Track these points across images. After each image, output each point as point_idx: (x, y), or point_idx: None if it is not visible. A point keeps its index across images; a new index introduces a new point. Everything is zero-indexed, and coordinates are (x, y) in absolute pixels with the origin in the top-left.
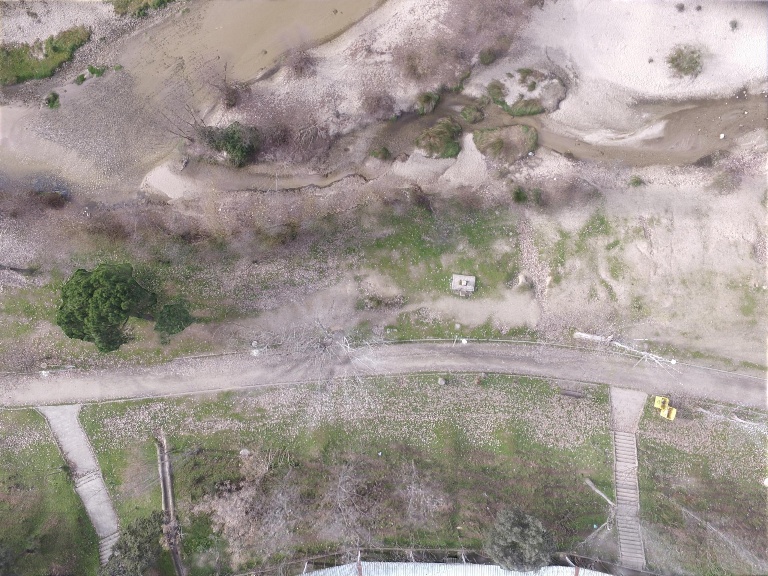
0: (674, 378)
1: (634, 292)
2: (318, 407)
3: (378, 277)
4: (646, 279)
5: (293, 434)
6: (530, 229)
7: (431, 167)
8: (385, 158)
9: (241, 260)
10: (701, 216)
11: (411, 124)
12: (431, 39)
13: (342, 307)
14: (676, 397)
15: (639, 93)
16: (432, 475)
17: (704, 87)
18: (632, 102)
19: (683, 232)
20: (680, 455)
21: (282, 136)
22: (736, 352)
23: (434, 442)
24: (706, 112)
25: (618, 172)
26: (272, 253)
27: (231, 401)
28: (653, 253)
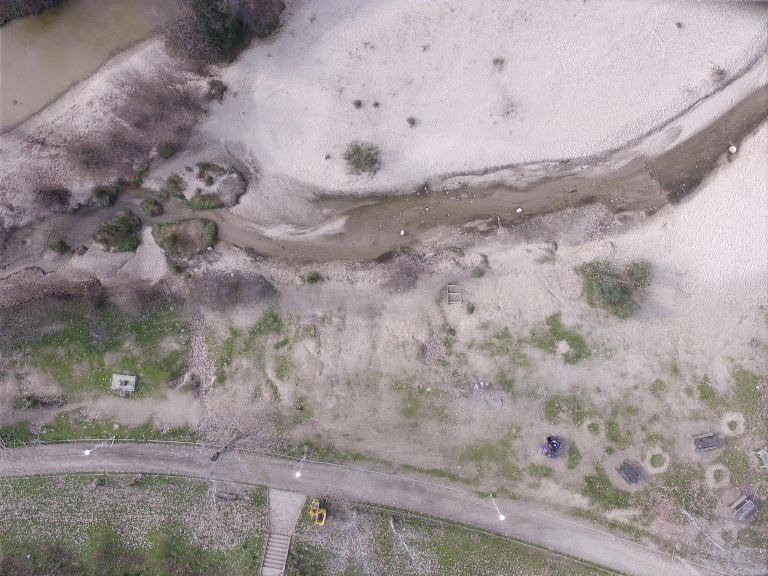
0: None
1: (297, 393)
2: None
3: (39, 375)
4: (310, 380)
5: None
6: (203, 326)
7: (109, 261)
8: (63, 251)
9: None
10: (374, 315)
11: (90, 217)
12: (107, 132)
13: None
14: (335, 499)
15: (319, 188)
16: None
17: (384, 183)
18: (312, 197)
19: (353, 331)
20: (335, 559)
21: None
22: (397, 455)
23: (86, 544)
24: (387, 208)
25: (298, 267)
26: None
27: None
28: (321, 353)
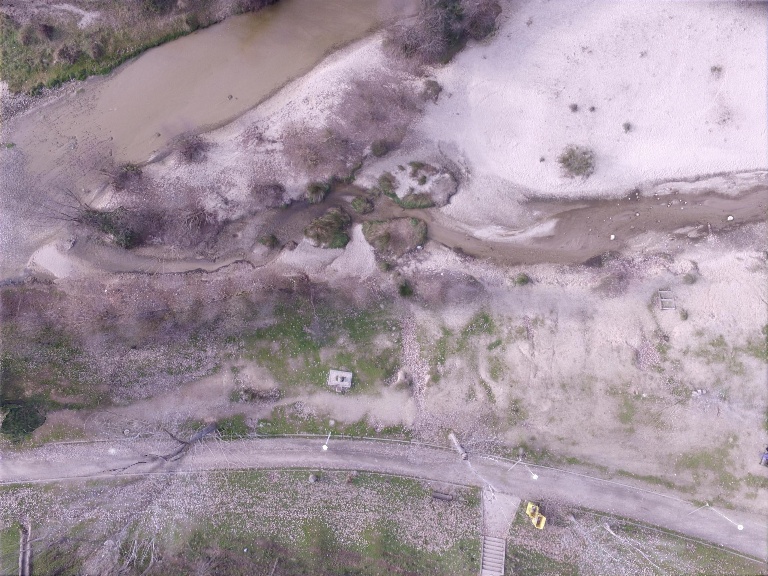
0: (548, 485)
1: (512, 394)
2: (187, 499)
3: (255, 369)
4: (525, 382)
5: (160, 525)
6: (414, 324)
7: (319, 257)
8: (273, 246)
9: (121, 344)
10: (586, 318)
11: (301, 212)
12: (323, 129)
13: (217, 398)
14: (549, 503)
15: (530, 191)
16: (294, 575)
17: (596, 187)
18: (523, 199)
19: (566, 334)
20: (550, 563)
21: (169, 221)
22: (612, 460)
23: (301, 540)
24: (597, 212)
25: (507, 269)
26: (153, 338)
27: (99, 490)
28: (534, 355)
